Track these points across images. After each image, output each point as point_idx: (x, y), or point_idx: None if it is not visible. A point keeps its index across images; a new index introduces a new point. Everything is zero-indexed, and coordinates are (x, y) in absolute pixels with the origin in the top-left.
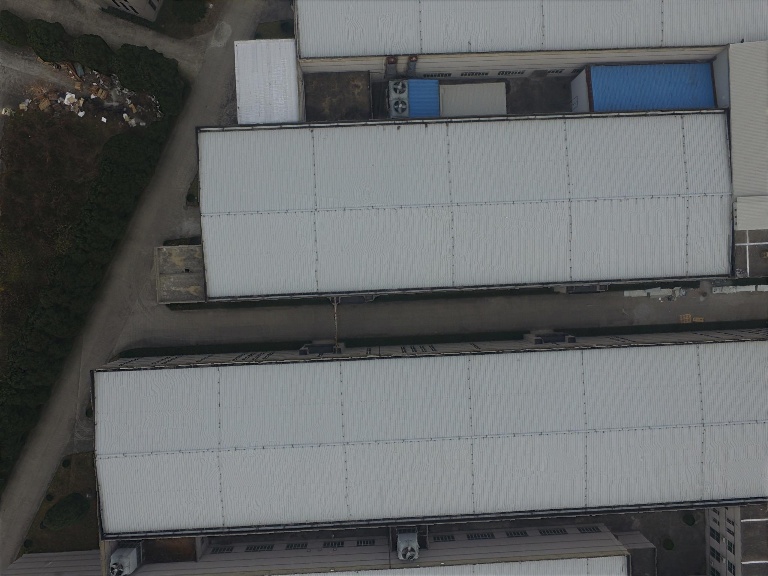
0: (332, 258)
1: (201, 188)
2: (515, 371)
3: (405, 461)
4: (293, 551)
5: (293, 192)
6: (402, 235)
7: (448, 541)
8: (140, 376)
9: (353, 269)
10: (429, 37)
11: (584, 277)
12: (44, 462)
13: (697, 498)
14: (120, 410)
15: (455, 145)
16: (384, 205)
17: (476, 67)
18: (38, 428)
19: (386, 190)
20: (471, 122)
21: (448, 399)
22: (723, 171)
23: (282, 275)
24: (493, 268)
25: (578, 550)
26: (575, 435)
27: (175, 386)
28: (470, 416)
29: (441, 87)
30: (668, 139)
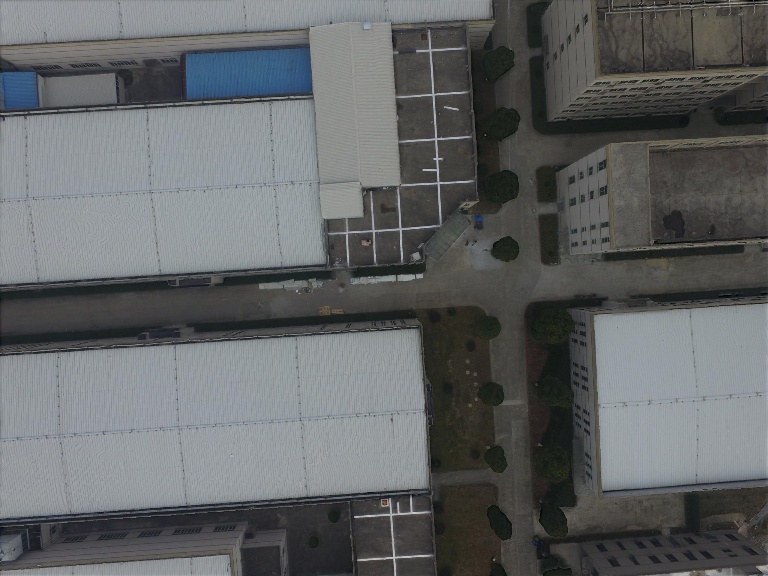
0: None
1: None
2: (105, 368)
3: None
4: None
5: None
6: None
7: (74, 542)
8: None
9: None
10: (3, 28)
11: (181, 270)
12: None
13: (303, 494)
14: None
15: (33, 138)
16: None
17: (73, 58)
18: None
19: None
20: (50, 114)
21: (36, 397)
22: (312, 158)
23: None
24: (92, 263)
25: (185, 549)
26: (167, 432)
27: None
28: (58, 414)
29: (47, 79)
30: (255, 127)
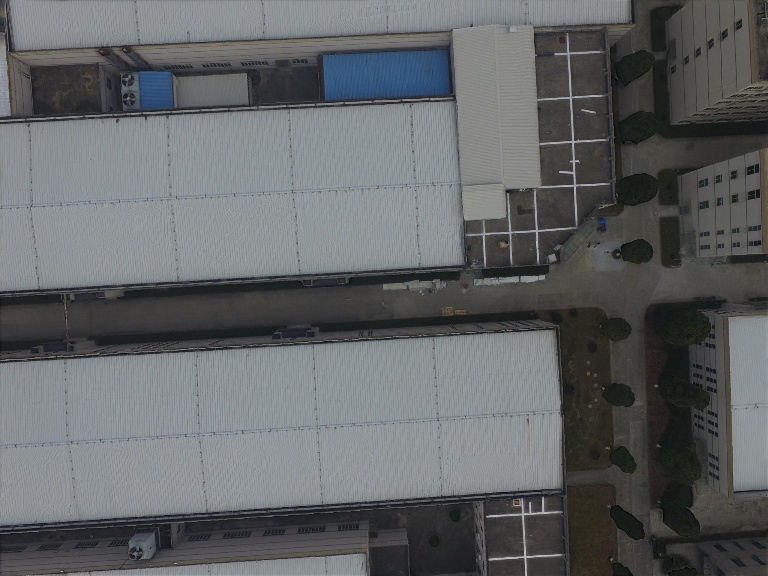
0: (57, 254)
1: None
2: (244, 367)
3: (130, 460)
4: (41, 552)
5: (8, 188)
6: (132, 230)
7: (201, 540)
8: None
9: (79, 265)
10: (146, 28)
11: (318, 270)
12: None
13: (437, 494)
14: None
15: (176, 137)
16: (102, 200)
17: (209, 58)
18: None
19: (106, 184)
20: (192, 114)
21: (175, 396)
22: (452, 160)
23: (7, 272)
24: (228, 262)
25: (318, 548)
26: (306, 431)
27: None
28: (197, 413)
29: (180, 79)
30: (396, 128)
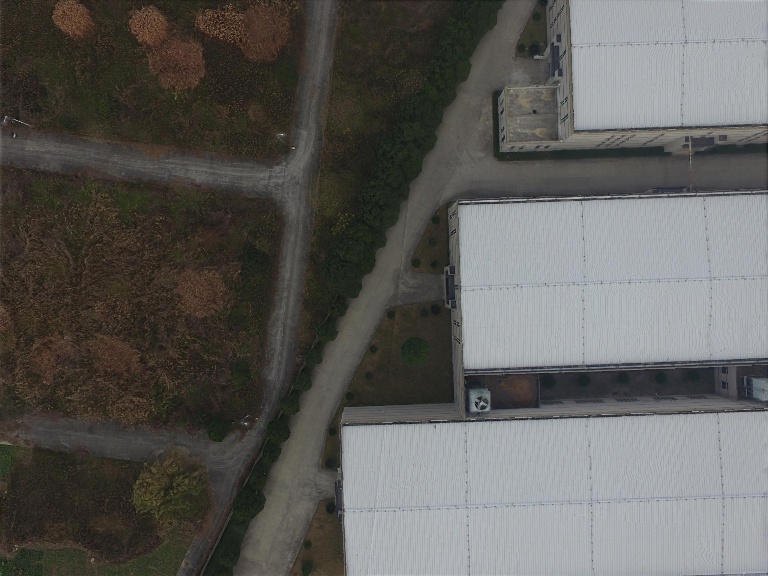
0: (692, 95)
1: (570, 20)
2: None
3: None
4: (630, 402)
5: (662, 24)
6: (757, 75)
7: None
8: (502, 209)
9: (712, 106)
10: None
11: None
12: (368, 313)
13: None
14: (484, 242)
15: None
16: (753, 38)
17: None
18: (363, 279)
19: (752, 24)
20: None
21: None
22: None
23: (641, 111)
24: None
25: None
26: None
27: (536, 220)
28: None
29: None
30: None
